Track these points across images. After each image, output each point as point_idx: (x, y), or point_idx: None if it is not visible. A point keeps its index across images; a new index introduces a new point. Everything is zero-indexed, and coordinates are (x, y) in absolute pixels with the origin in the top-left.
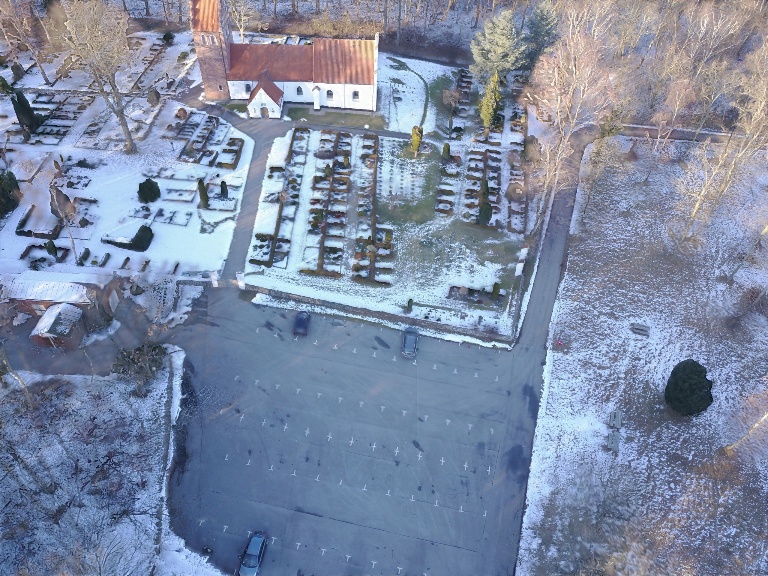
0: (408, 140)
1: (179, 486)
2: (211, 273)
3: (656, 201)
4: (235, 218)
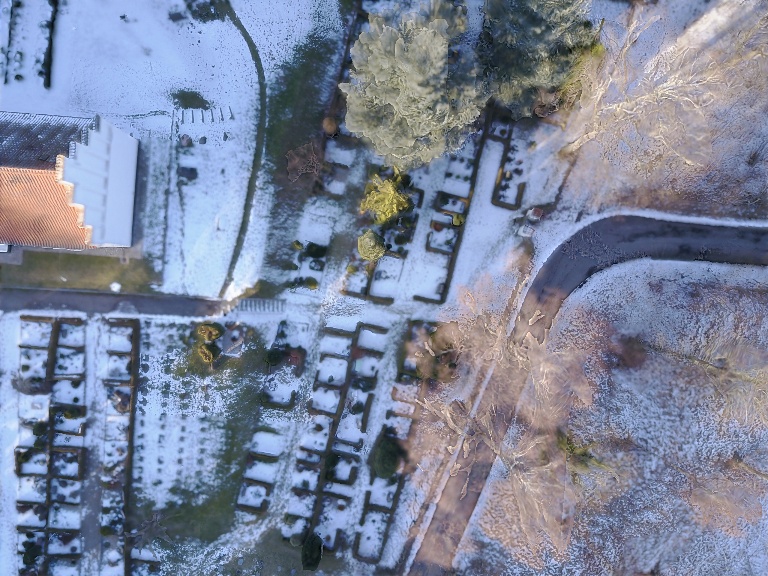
0: (201, 320)
1: None
2: None
3: (627, 494)
4: None
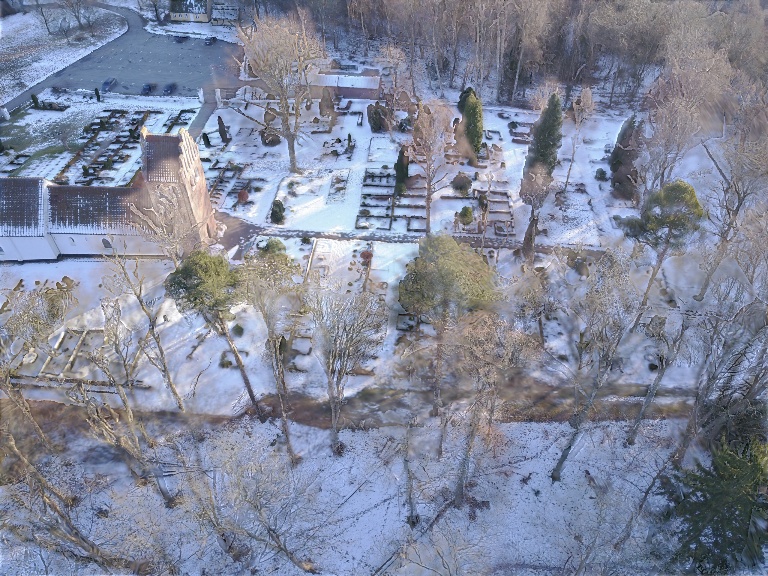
0: None
1: (241, 52)
2: (219, 91)
3: None
4: (202, 134)
